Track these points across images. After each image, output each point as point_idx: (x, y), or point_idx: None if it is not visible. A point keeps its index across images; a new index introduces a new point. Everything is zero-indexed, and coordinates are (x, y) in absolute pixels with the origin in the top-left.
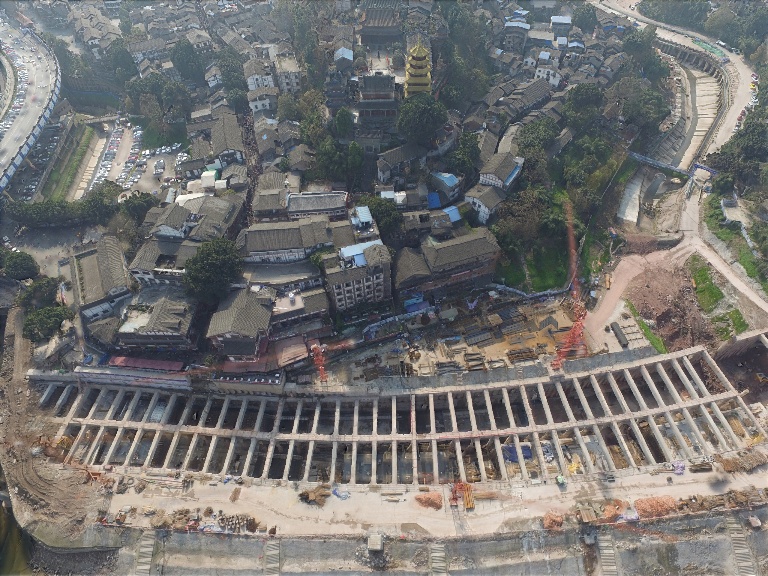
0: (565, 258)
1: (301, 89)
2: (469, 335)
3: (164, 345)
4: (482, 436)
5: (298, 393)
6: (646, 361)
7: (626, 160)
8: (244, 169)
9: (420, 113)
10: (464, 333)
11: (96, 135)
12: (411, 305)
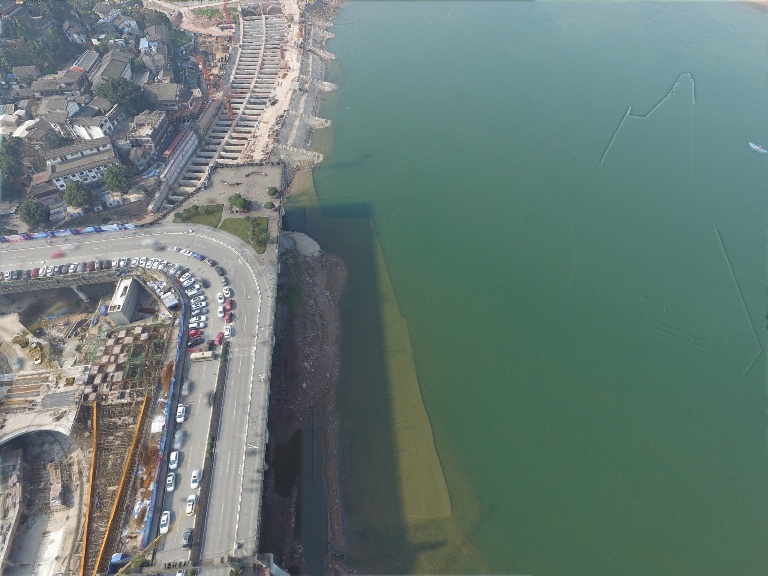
0: None
1: None
2: (207, 60)
3: None
4: None
5: (217, 107)
6: (242, 28)
7: None
8: None
9: None
10: (205, 62)
11: None
12: None
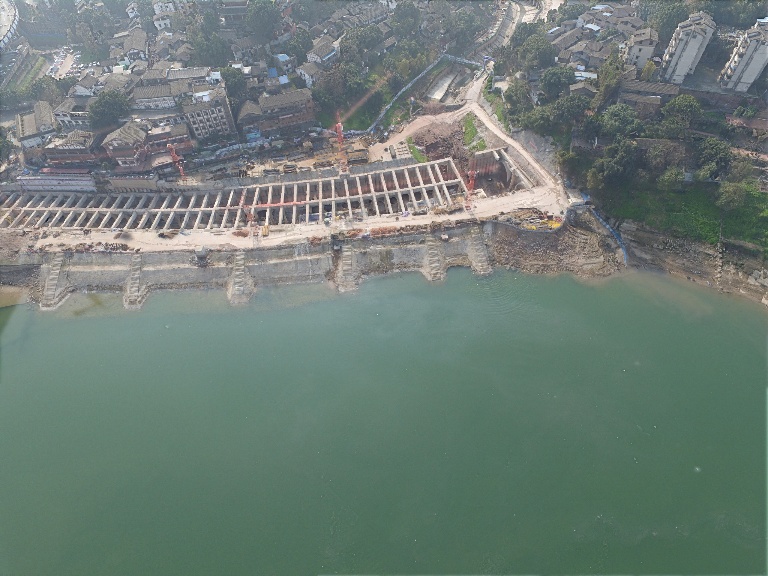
0: (373, 115)
1: (193, 12)
2: (290, 156)
3: (77, 160)
4: (285, 205)
5: (167, 188)
6: (408, 166)
7: (442, 60)
8: (145, 63)
9: (258, 10)
10: (287, 155)
11: (47, 63)
12: (252, 138)
